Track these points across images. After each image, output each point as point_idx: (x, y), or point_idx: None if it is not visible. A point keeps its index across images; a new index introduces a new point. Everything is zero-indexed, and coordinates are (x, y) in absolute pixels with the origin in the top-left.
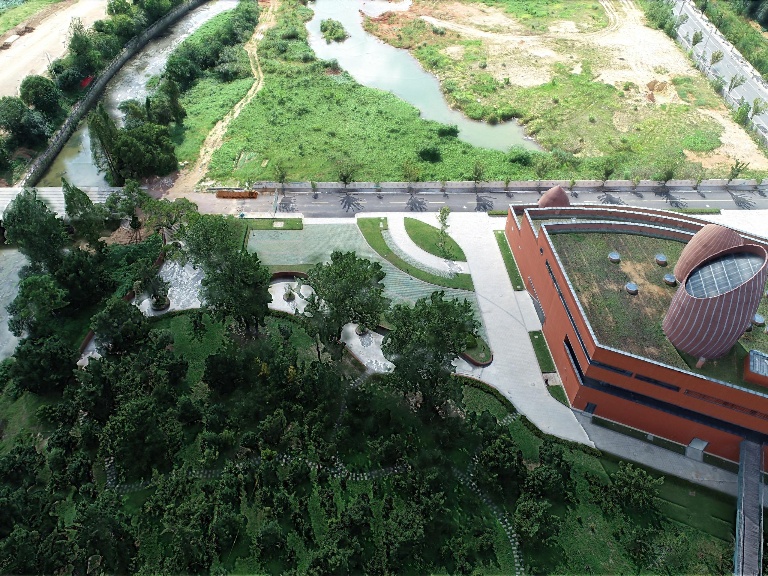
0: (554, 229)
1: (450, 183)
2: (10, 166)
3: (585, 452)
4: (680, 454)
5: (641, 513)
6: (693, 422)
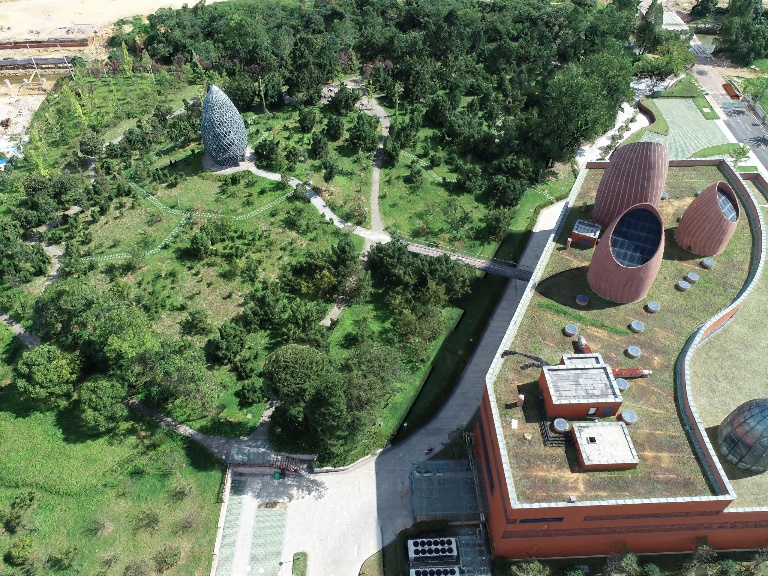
0: None
1: None
2: (704, 16)
3: None
4: None
5: (485, 235)
6: None
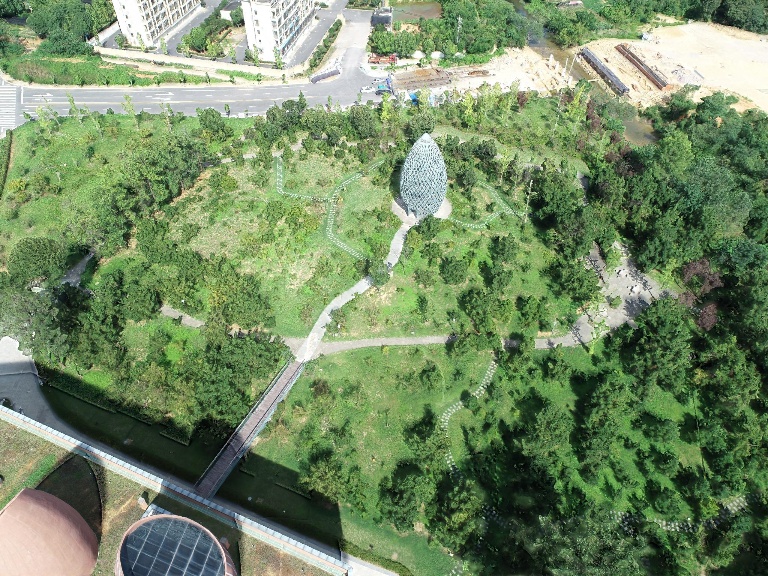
0: None
1: None
2: None
3: (356, 546)
4: None
5: None
6: None
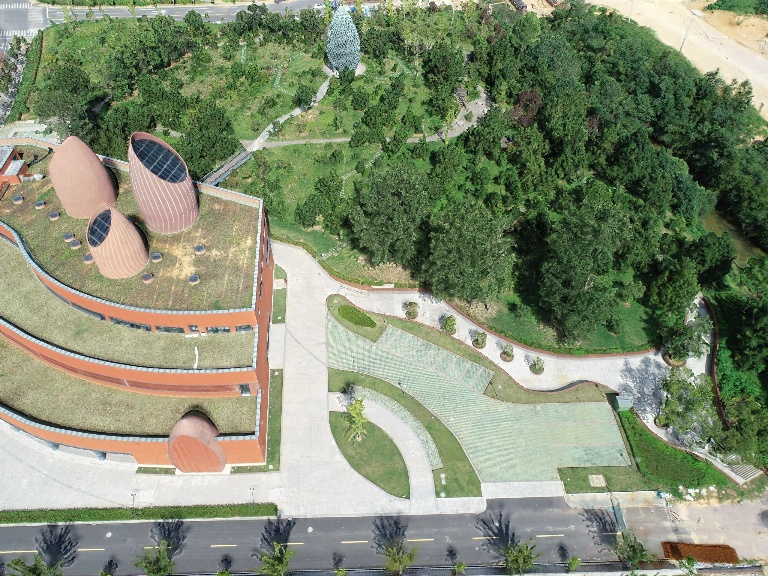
0: None
1: None
2: None
3: None
4: None
5: None
6: None
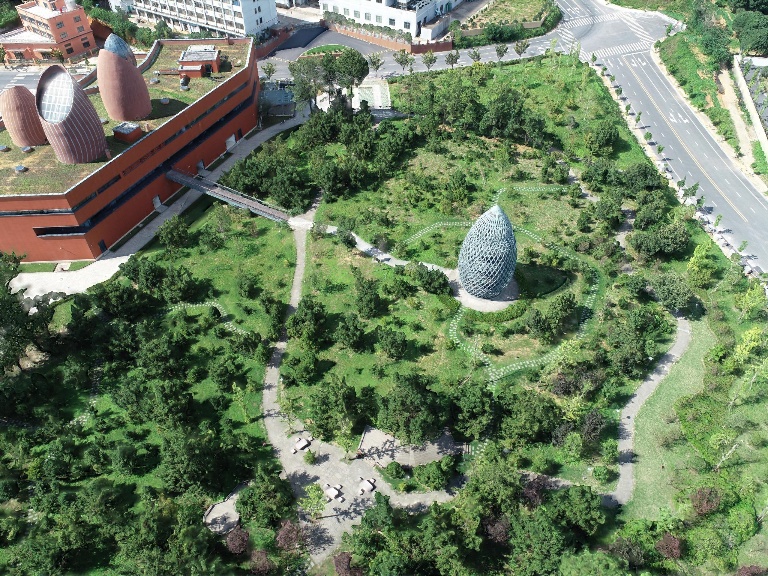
0: None
1: None
2: None
3: None
4: (159, 215)
5: (191, 240)
6: (143, 190)
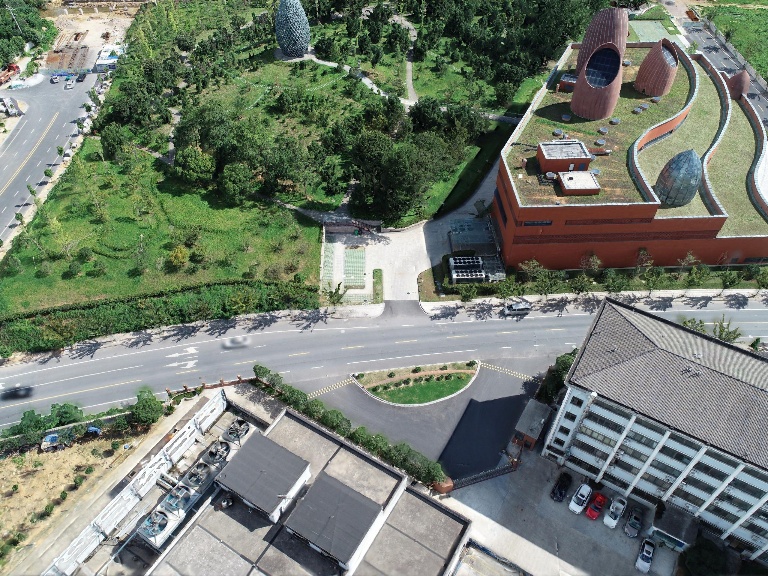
0: (676, 50)
1: (761, 79)
2: None
3: None
4: None
5: (495, 105)
6: None
